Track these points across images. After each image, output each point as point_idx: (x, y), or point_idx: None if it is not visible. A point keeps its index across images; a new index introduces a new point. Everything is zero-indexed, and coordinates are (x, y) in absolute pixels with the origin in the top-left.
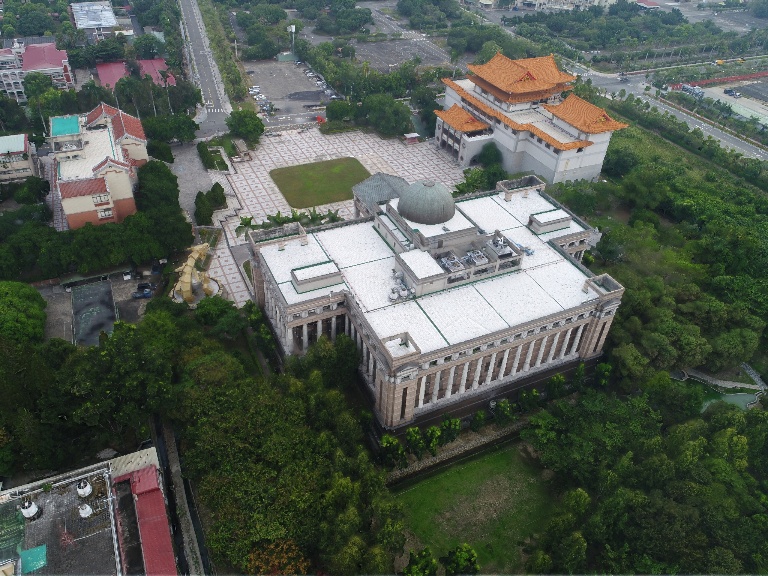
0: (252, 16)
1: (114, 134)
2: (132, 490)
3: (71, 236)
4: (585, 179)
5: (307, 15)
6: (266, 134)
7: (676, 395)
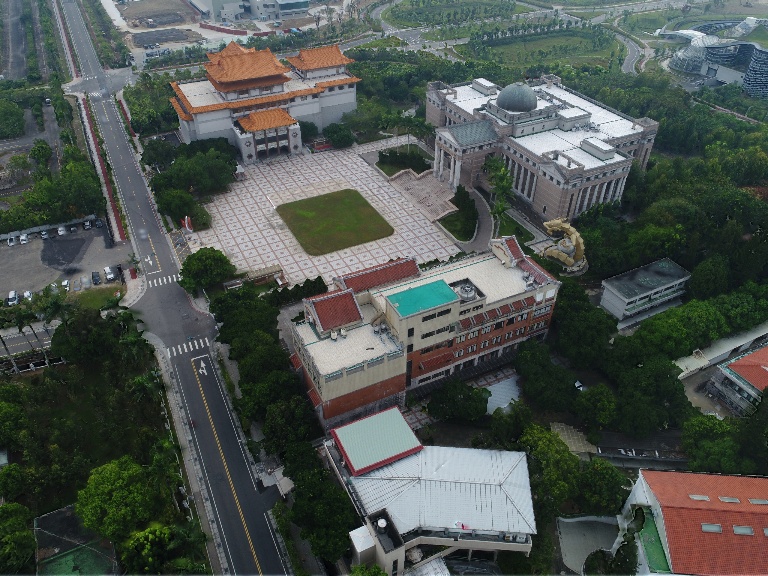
0: None
1: None
2: None
3: (568, 308)
4: None
5: None
6: None
7: None
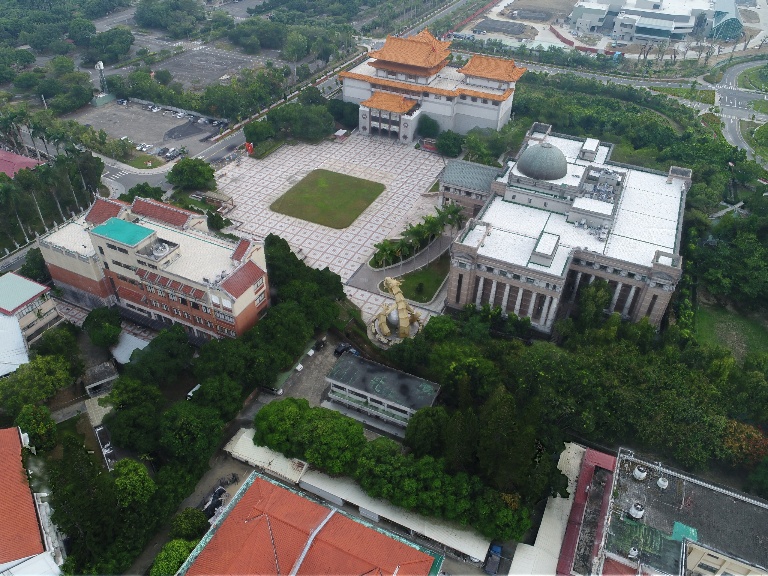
0: None
1: (165, 222)
2: (610, 470)
3: None
4: (506, 121)
5: (59, 50)
6: None
7: (743, 225)
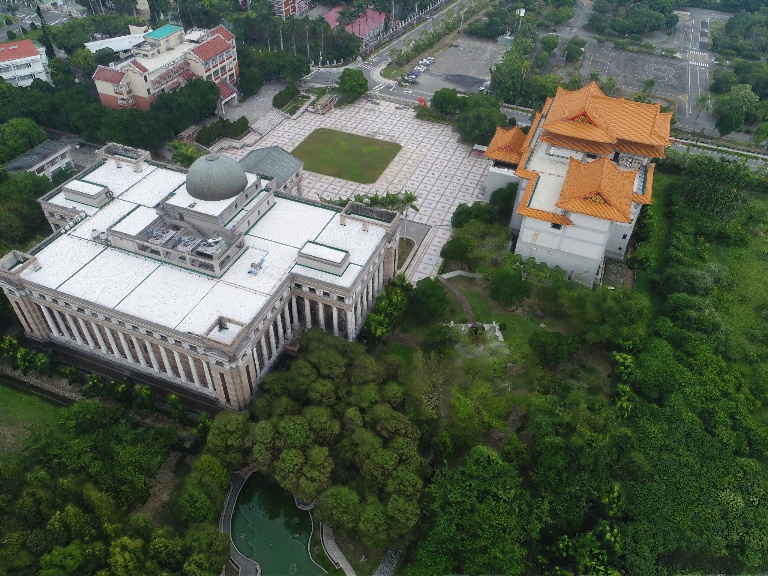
0: None
1: None
2: None
3: None
4: (570, 270)
5: (595, 7)
6: (370, 99)
7: None
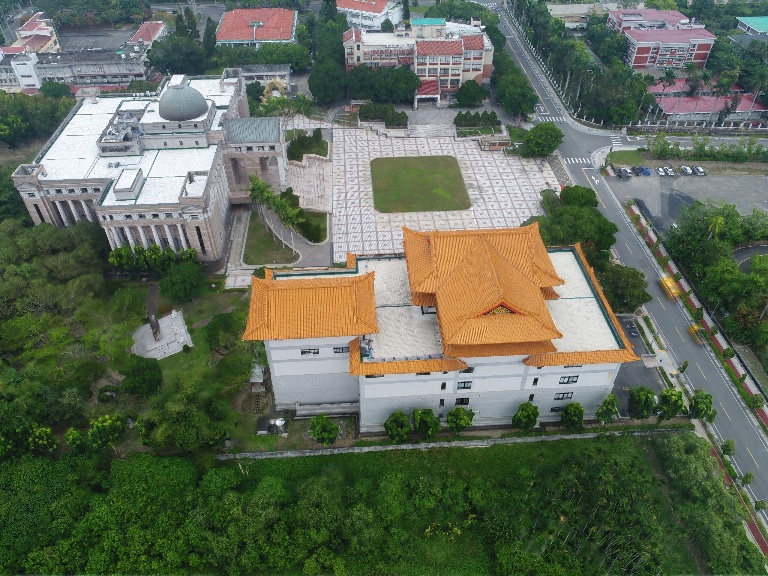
0: None
1: None
2: None
3: None
4: None
5: None
6: (546, 164)
7: None
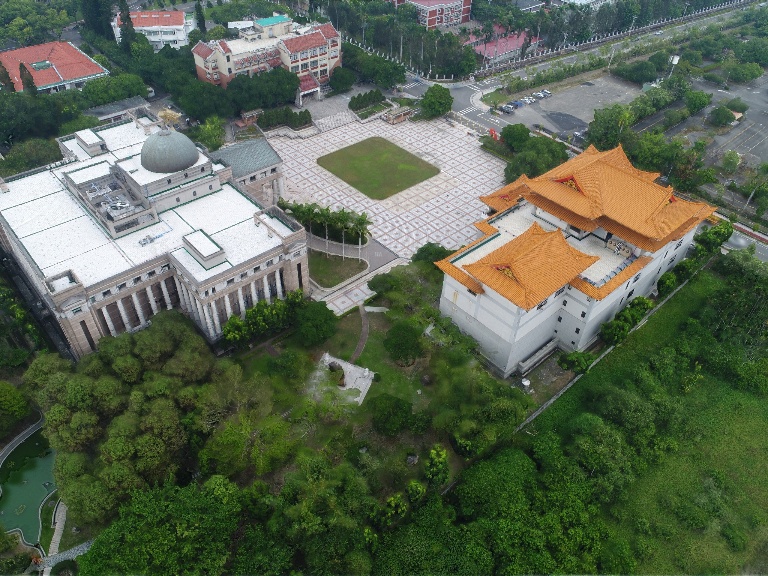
0: (717, 43)
1: None
2: None
3: None
4: (486, 345)
5: None
6: (450, 120)
7: None
